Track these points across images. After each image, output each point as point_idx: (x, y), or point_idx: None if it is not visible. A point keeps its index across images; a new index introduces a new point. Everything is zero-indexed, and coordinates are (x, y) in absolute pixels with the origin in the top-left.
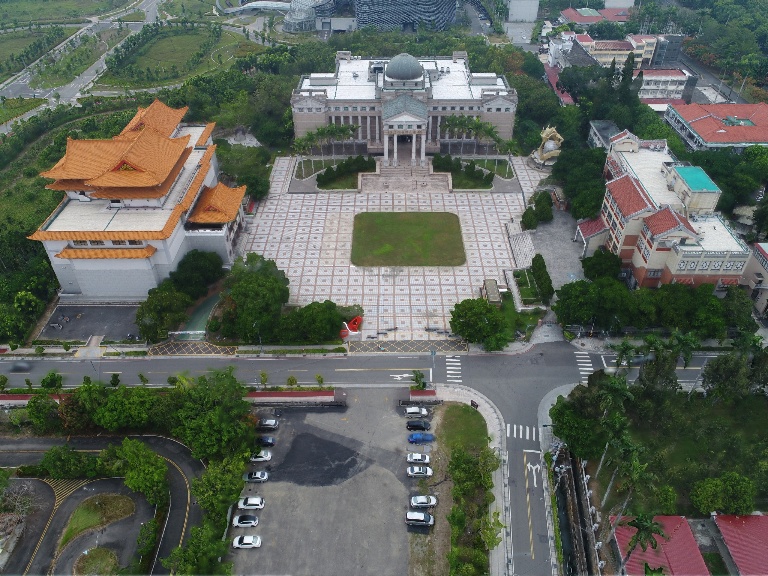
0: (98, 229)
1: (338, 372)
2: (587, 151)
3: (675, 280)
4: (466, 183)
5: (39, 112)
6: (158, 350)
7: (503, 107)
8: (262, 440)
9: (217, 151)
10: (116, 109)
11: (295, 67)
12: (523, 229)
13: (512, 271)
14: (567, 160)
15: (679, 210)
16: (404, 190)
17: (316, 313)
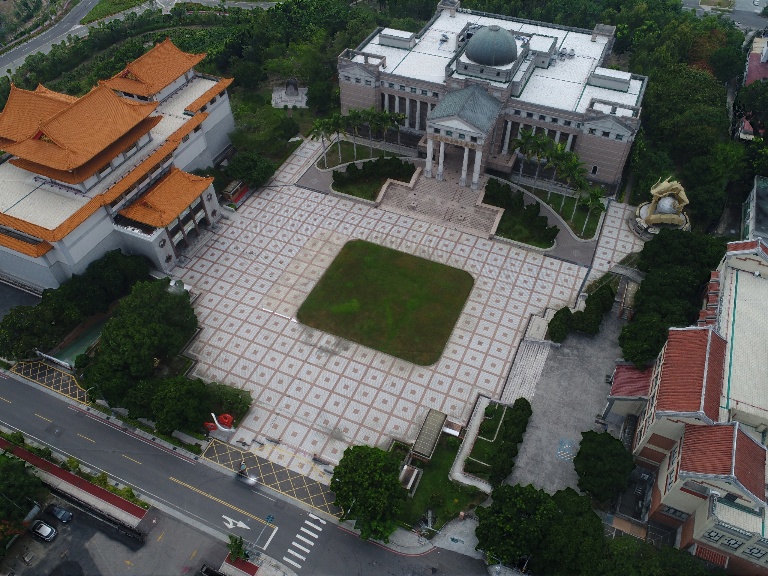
0: (4, 206)
1: (170, 482)
2: (699, 242)
3: (695, 548)
4: (518, 231)
5: (124, 15)
6: (23, 367)
7: (613, 132)
8: (27, 550)
9: (239, 111)
10: (203, 24)
11: (411, 4)
12: (548, 334)
13: (489, 401)
14: (664, 245)
15: (765, 427)
16: (432, 218)
17: (169, 398)
